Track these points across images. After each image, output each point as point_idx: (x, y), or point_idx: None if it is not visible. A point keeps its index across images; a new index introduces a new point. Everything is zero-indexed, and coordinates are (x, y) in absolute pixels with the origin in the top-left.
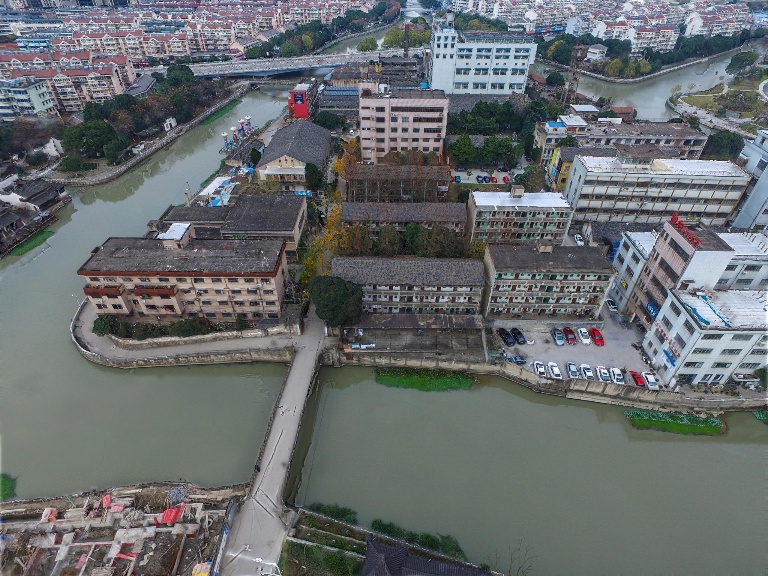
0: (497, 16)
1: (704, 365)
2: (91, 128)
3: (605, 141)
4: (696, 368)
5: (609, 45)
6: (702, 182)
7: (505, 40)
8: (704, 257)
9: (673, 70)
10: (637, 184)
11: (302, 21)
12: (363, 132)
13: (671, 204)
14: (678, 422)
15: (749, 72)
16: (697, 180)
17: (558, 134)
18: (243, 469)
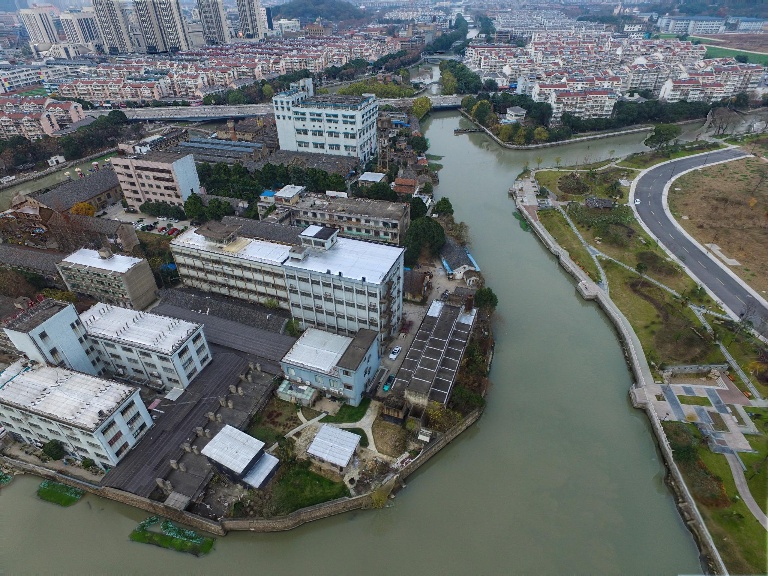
0: (477, 69)
1: (15, 427)
2: None
3: (312, 213)
4: (14, 429)
5: (529, 108)
6: (259, 267)
7: (334, 106)
8: (12, 334)
9: (598, 138)
10: (212, 261)
11: (301, 69)
12: (122, 184)
13: (248, 283)
14: None
15: (678, 146)
16: (253, 265)
17: (269, 202)
18: None
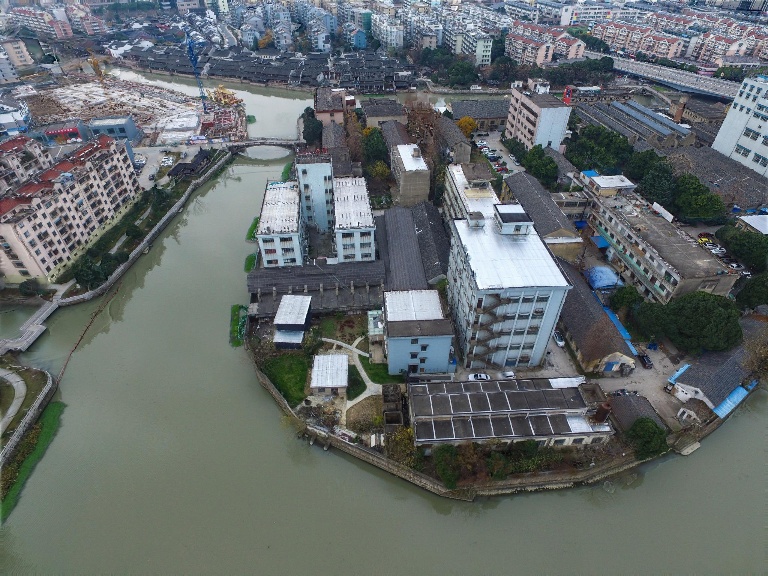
0: None
1: None
2: (459, 65)
3: (609, 216)
4: None
5: None
6: None
7: None
8: None
9: None
10: None
11: None
12: (509, 115)
13: None
14: (255, 229)
15: None
16: None
17: (583, 183)
18: (259, 156)
